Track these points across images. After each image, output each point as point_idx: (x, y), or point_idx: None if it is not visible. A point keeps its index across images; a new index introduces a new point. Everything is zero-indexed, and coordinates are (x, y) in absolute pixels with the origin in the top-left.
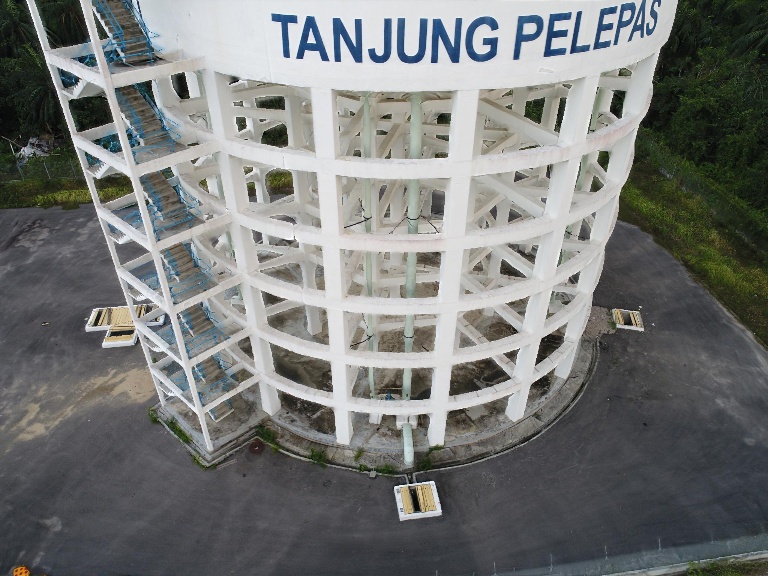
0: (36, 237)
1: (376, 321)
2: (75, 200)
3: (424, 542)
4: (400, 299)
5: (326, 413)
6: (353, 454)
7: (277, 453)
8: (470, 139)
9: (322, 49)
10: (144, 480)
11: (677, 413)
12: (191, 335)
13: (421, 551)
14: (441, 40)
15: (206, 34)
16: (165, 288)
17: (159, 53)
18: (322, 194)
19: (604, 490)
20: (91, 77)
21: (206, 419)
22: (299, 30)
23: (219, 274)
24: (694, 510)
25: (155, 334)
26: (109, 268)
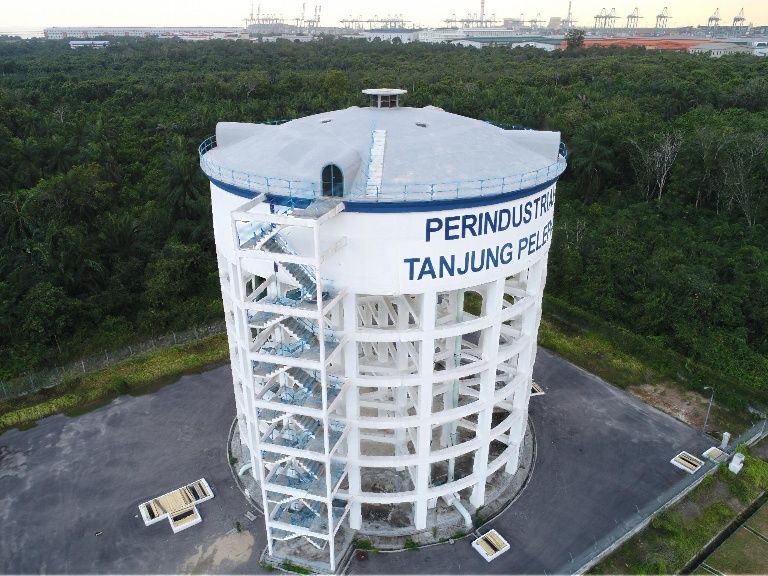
0: (14, 464)
1: (405, 435)
2: (27, 419)
3: (511, 568)
4: (462, 407)
5: (395, 514)
6: (431, 534)
7: (379, 554)
8: (501, 303)
9: (433, 273)
10: None
11: (592, 438)
12: (315, 479)
13: (513, 574)
14: (490, 258)
15: (353, 274)
16: (328, 442)
17: (287, 286)
18: (424, 352)
19: (584, 496)
20: (304, 314)
21: (313, 551)
22: (420, 265)
23: (228, 443)
24: (633, 489)
25: (289, 487)
26: (120, 468)
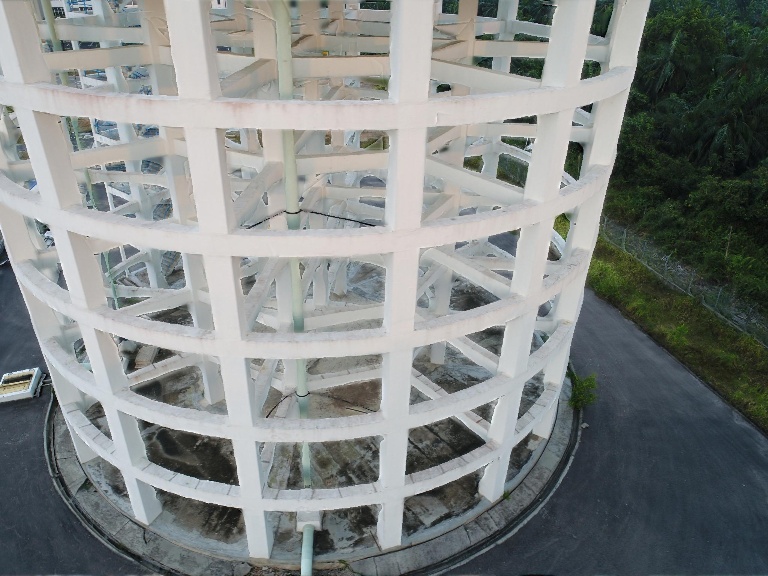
0: None
1: None
2: None
3: None
4: None
5: None
6: None
7: None
8: None
9: None
10: (118, 262)
11: None
12: None
13: None
14: None
15: None
16: None
17: None
18: None
19: None
20: None
21: None
22: None
23: None
24: None
25: None
26: None
